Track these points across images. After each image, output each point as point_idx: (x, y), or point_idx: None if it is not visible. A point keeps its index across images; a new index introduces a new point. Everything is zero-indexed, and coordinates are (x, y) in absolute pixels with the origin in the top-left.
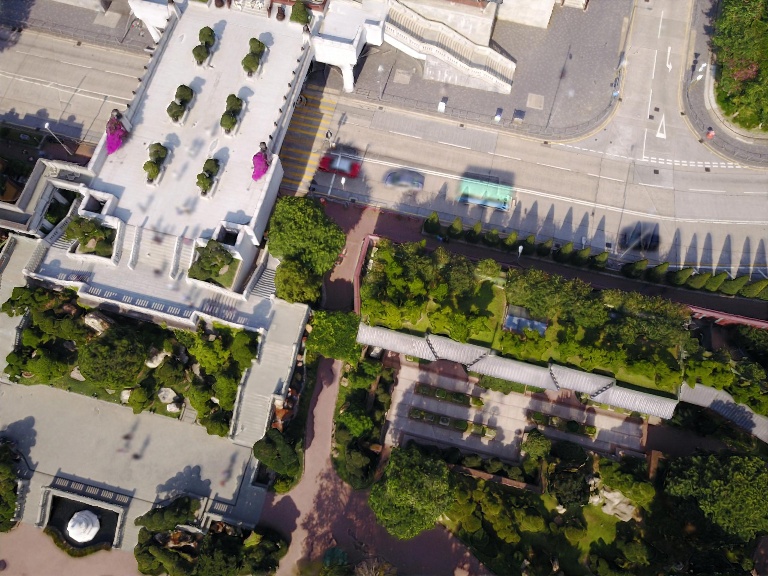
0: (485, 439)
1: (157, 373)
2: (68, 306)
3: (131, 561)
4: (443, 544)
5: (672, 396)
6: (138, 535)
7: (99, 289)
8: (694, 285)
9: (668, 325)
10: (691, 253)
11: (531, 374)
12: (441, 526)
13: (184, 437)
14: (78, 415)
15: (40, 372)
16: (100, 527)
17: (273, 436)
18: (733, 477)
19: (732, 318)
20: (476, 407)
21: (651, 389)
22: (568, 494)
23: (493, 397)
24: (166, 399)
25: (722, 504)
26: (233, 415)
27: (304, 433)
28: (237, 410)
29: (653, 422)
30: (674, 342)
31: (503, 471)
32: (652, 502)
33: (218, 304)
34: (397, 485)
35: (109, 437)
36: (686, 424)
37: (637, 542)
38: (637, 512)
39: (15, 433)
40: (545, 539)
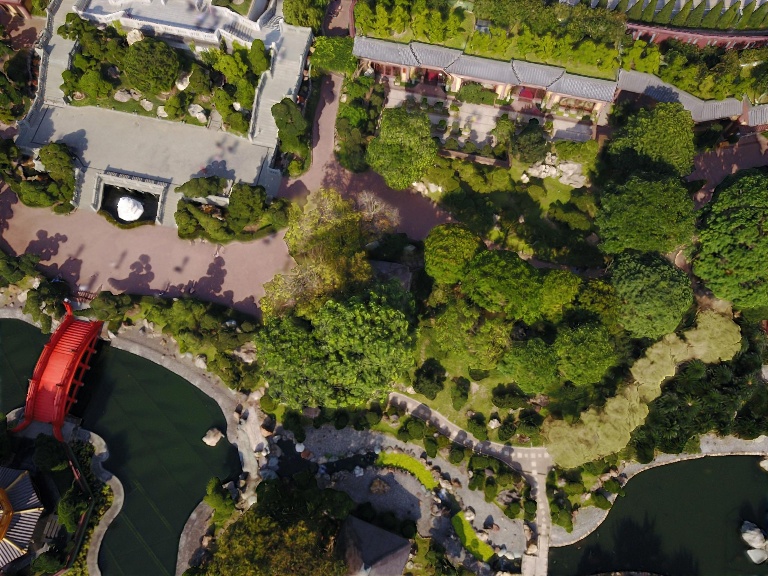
0: (462, 138)
1: (187, 90)
2: (111, 39)
3: (171, 233)
4: (429, 212)
5: (612, 80)
6: (177, 206)
7: (137, 19)
8: (632, 16)
9: (606, 21)
10: (631, 1)
11: (497, 71)
12: (427, 198)
13: (211, 141)
14: (122, 128)
15: (91, 82)
16: (144, 211)
17: (287, 101)
18: (658, 114)
19: (662, 31)
20: (454, 116)
21: (595, 77)
22: (528, 144)
23: (468, 109)
24: (195, 113)
25: (650, 136)
26: (252, 115)
27: (311, 136)
28: (255, 113)
29: (601, 124)
30: (612, 38)
31: (477, 153)
32: (598, 163)
33: (236, 30)
34: (388, 123)
35: (149, 142)
36: (626, 113)
37: (587, 196)
38: (587, 180)
39: (70, 141)
40: (512, 200)
